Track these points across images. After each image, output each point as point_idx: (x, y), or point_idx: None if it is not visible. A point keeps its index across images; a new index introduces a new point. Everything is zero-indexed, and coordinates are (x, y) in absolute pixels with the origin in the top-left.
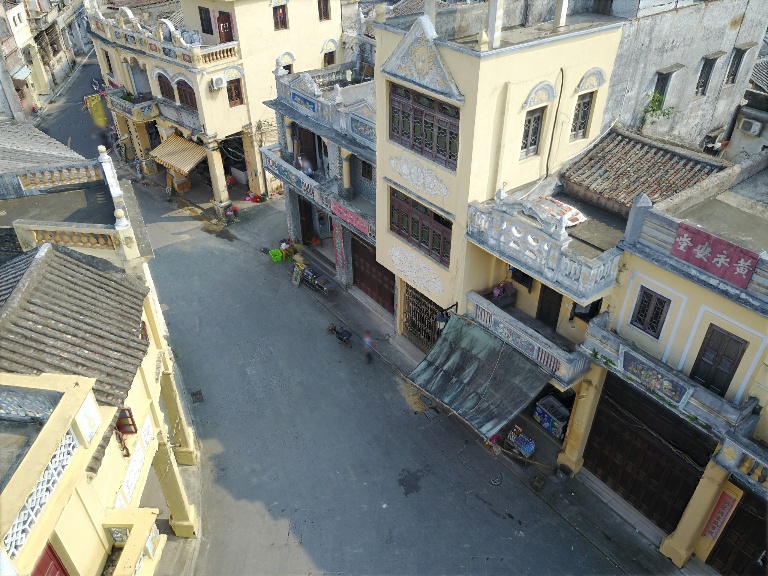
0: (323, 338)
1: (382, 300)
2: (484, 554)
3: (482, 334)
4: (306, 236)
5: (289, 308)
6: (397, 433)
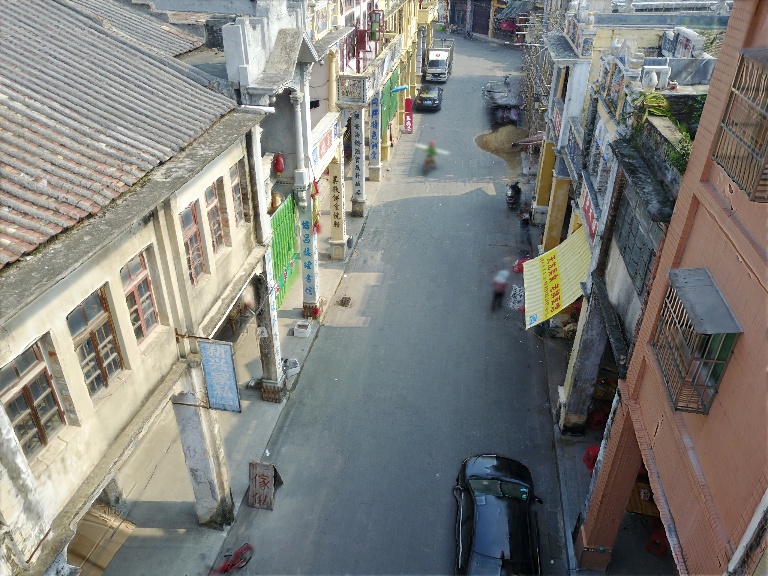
0: (462, 39)
1: (483, 31)
2: (514, 55)
3: (518, 2)
4: (452, 23)
5: (448, 36)
6: (489, 47)
